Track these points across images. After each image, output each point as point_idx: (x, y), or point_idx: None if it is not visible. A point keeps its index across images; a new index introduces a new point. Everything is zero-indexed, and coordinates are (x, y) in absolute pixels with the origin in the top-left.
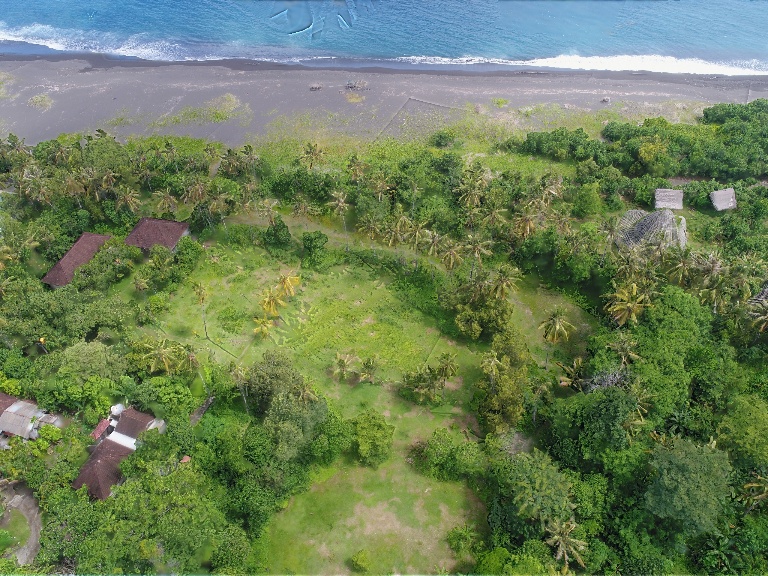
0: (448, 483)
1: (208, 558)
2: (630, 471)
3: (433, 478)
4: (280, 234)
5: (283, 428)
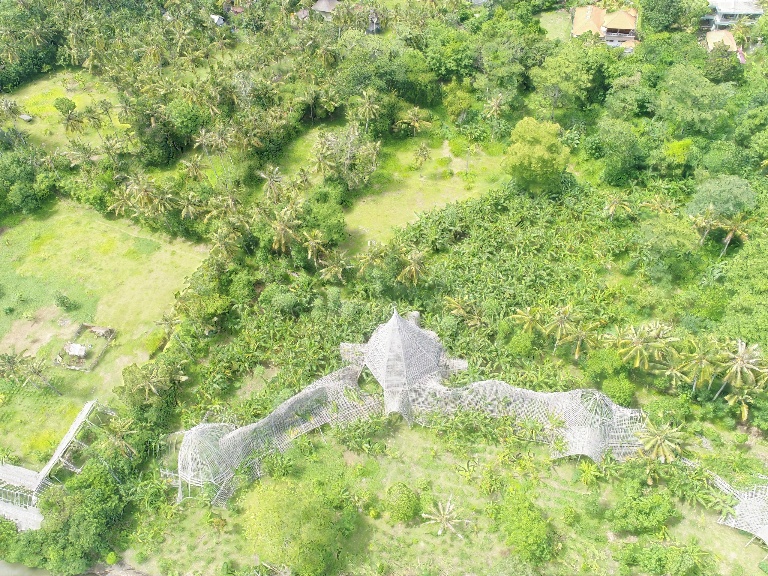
0: None
1: None
2: None
3: None
4: None
5: None
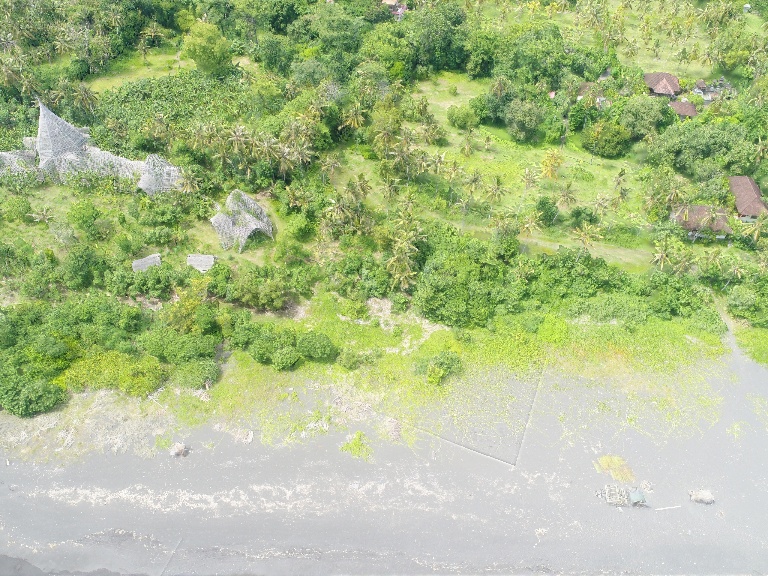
0: None
1: None
2: None
3: None
4: None
5: None
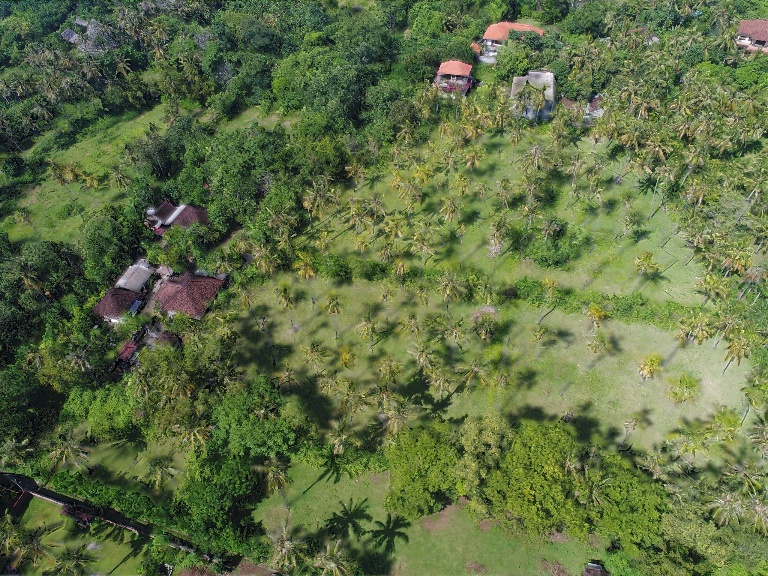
0: (233, 119)
1: None
2: None
3: (229, 123)
4: None
5: (196, 127)
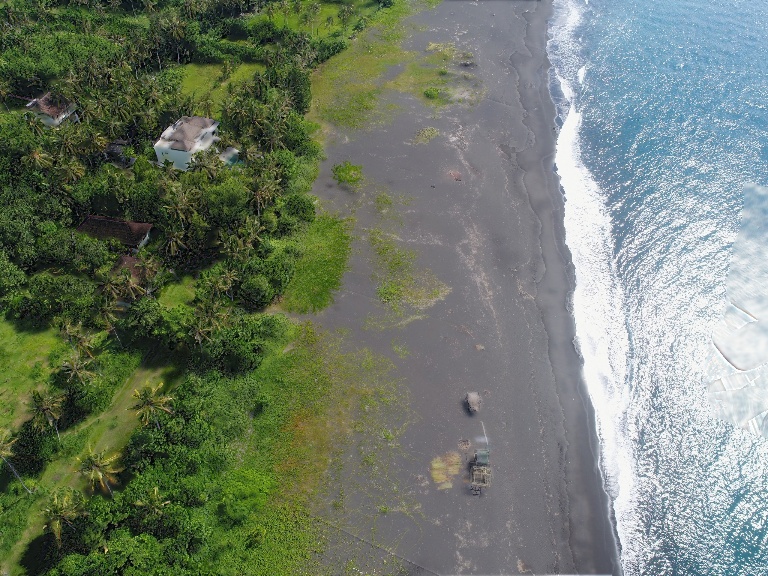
0: None
1: None
2: None
3: None
4: None
5: None
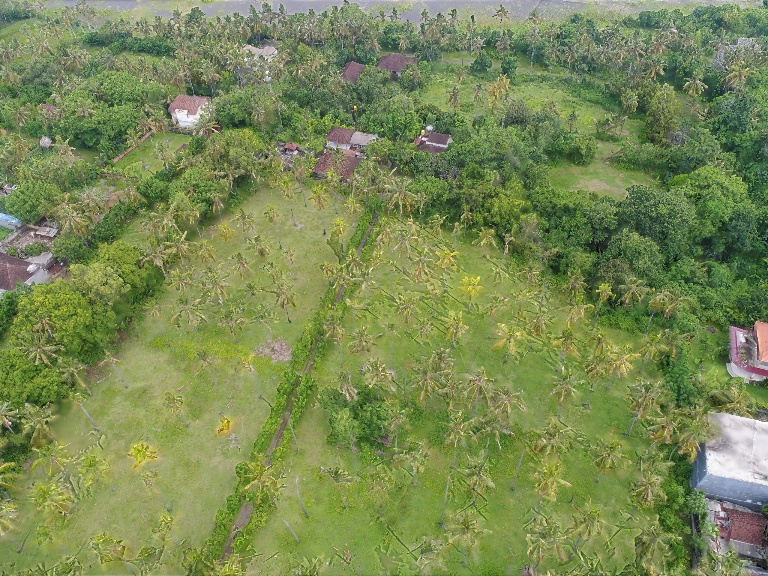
0: (633, 172)
1: (525, 168)
2: (751, 145)
3: (623, 170)
4: (486, 61)
5: (544, 125)
